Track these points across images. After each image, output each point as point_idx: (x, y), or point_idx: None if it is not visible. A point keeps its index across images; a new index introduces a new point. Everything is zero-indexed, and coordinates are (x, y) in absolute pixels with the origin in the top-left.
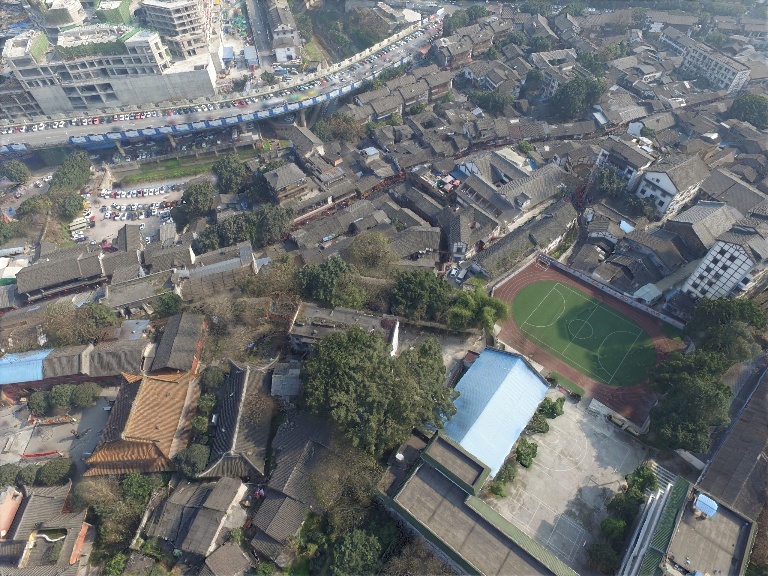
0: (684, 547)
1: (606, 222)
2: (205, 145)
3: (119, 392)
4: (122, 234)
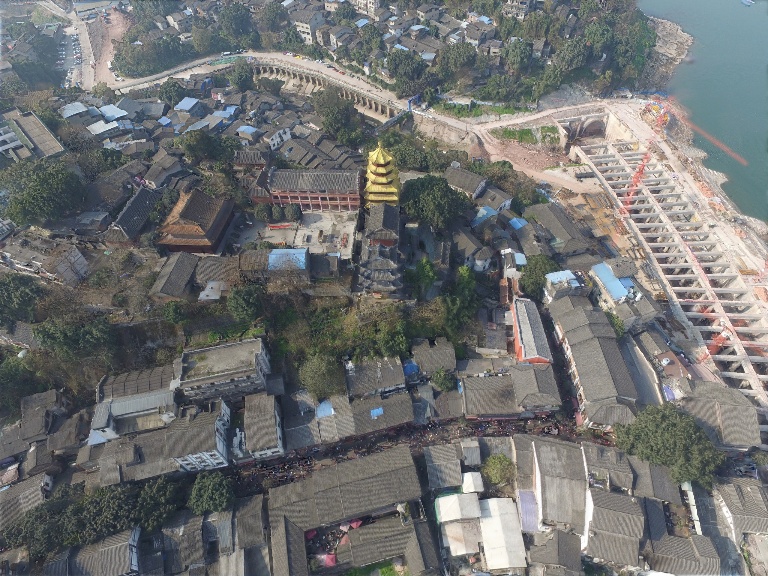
0: None
1: None
2: None
3: (209, 226)
4: (298, 569)
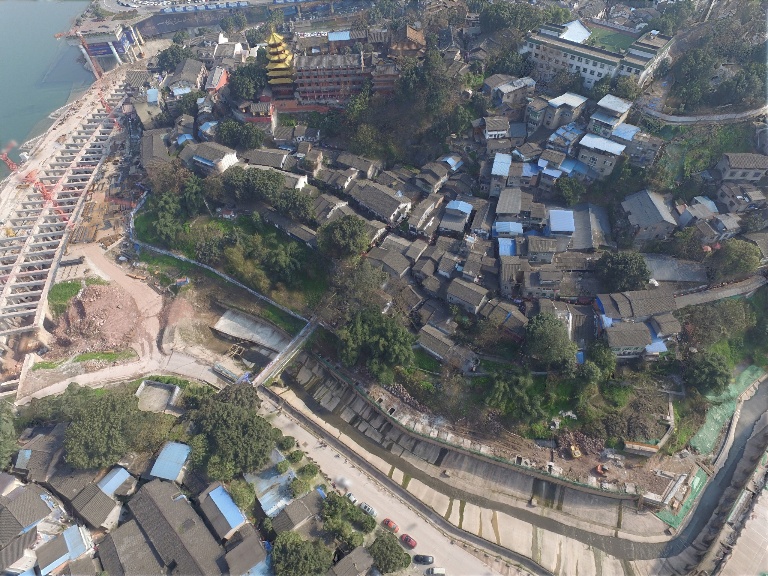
0: None
1: (623, 7)
2: (354, 11)
3: (392, 36)
4: None
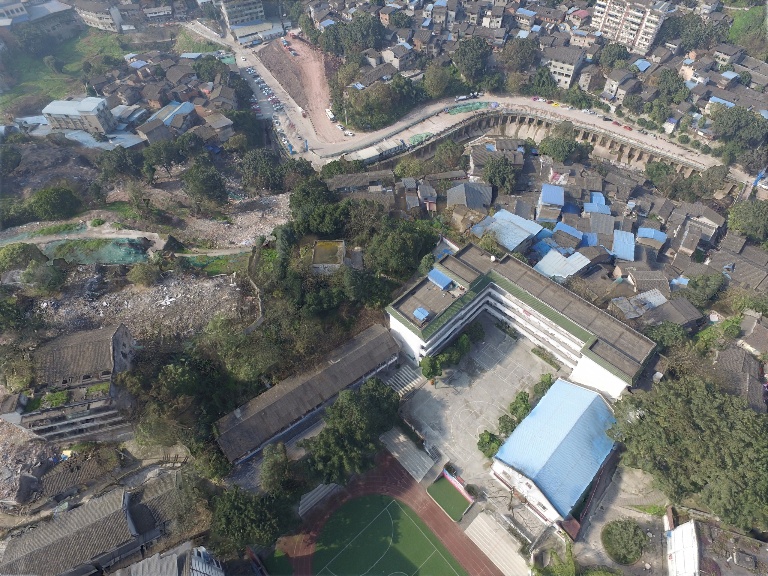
0: (443, 302)
1: None
2: None
3: None
4: None
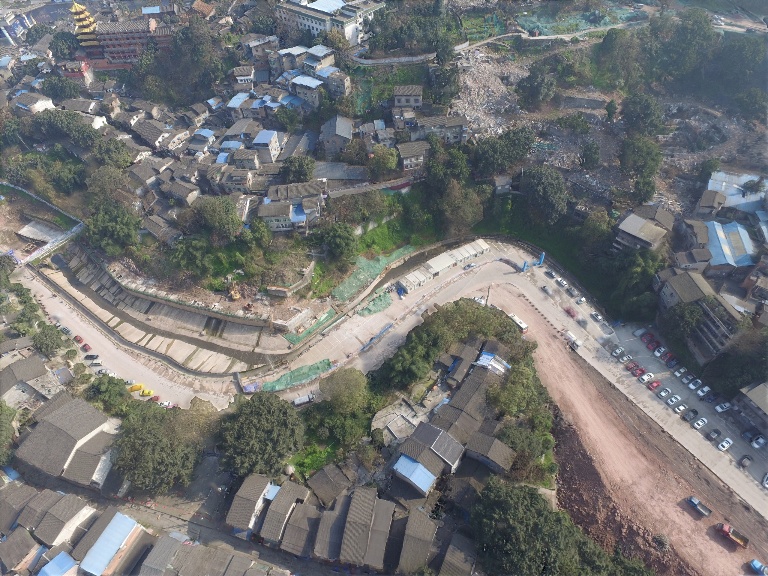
0: None
1: None
2: None
3: None
4: None
